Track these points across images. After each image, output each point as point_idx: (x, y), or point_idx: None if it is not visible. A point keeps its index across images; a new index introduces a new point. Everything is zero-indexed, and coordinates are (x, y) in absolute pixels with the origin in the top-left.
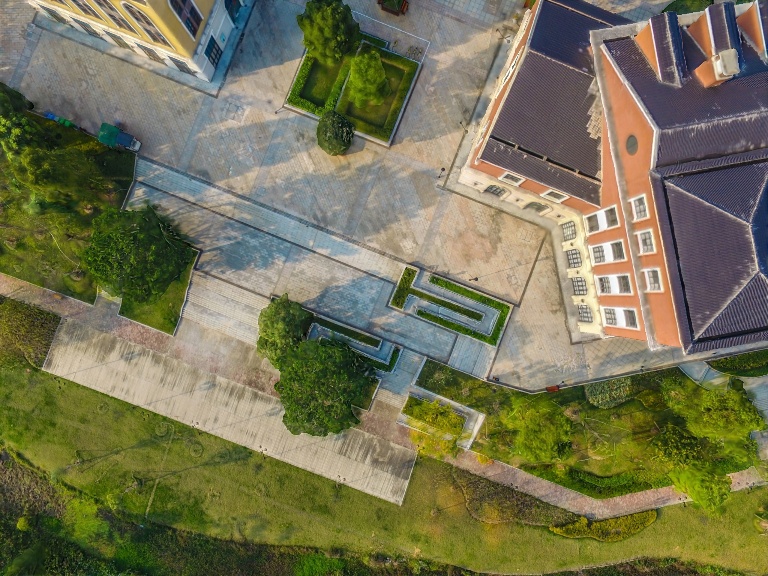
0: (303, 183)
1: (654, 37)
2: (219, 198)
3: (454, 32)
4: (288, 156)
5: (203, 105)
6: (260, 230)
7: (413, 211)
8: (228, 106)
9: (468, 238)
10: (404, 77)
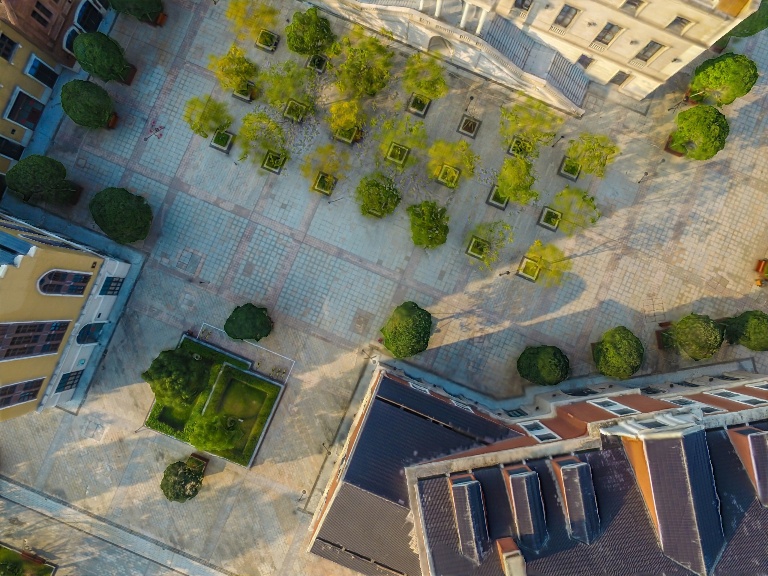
0: (161, 504)
1: (455, 508)
2: (75, 516)
3: (319, 351)
4: (147, 476)
5: (62, 422)
6: (118, 546)
7: (272, 534)
8: (88, 424)
9: (328, 563)
10: (265, 401)
